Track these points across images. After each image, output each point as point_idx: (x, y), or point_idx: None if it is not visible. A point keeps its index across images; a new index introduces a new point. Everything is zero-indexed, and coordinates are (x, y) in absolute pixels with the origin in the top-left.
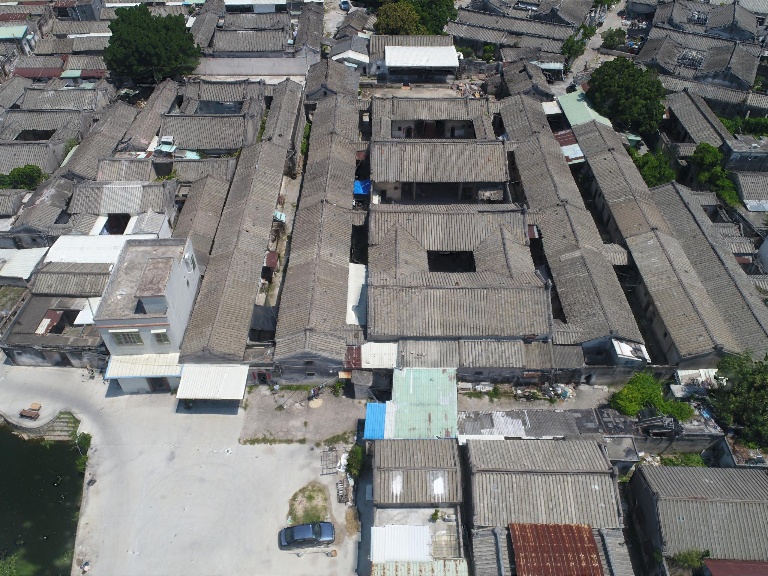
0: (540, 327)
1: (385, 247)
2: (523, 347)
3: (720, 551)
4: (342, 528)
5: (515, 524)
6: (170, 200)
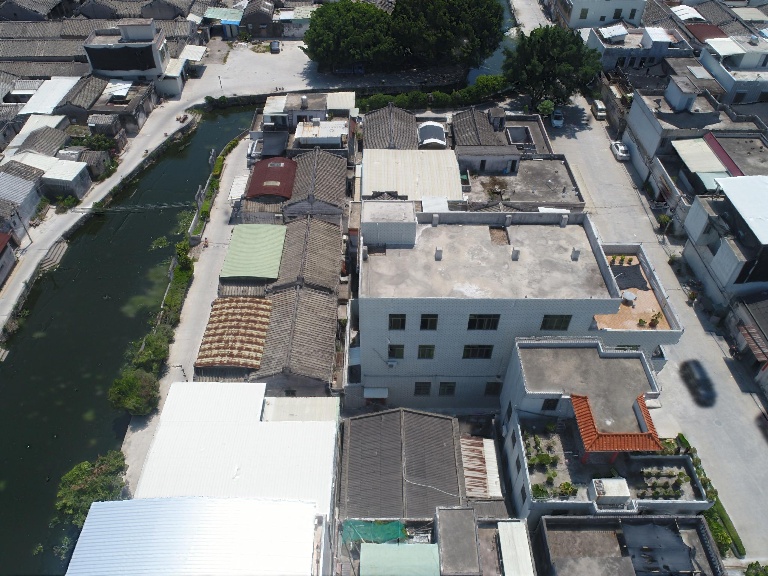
0: None
1: (122, 6)
2: None
3: None
4: None
5: None
6: None
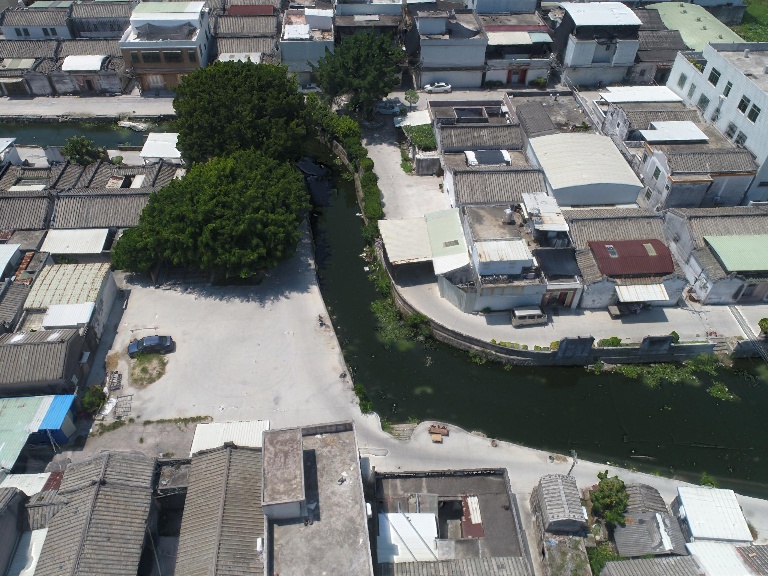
0: None
1: None
2: None
3: None
4: (122, 357)
5: None
6: None
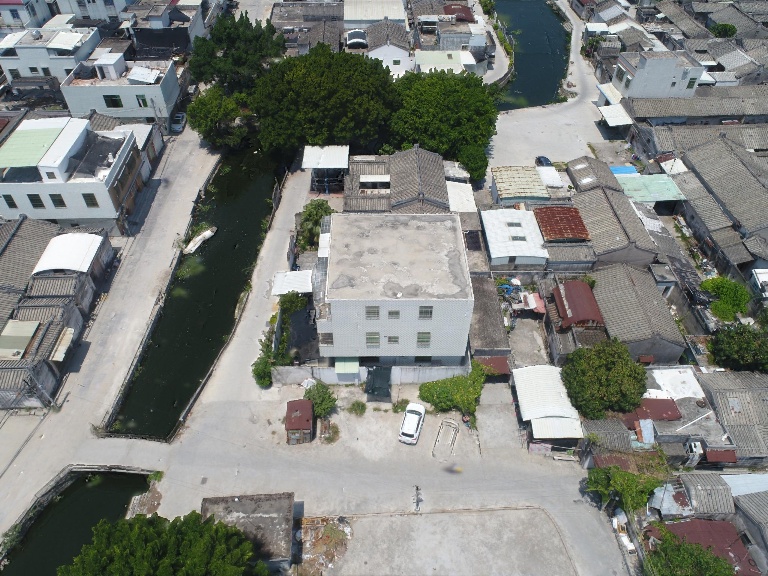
0: (749, 223)
1: None
2: (727, 225)
3: (600, 298)
4: None
5: (578, 210)
6: (754, 79)
